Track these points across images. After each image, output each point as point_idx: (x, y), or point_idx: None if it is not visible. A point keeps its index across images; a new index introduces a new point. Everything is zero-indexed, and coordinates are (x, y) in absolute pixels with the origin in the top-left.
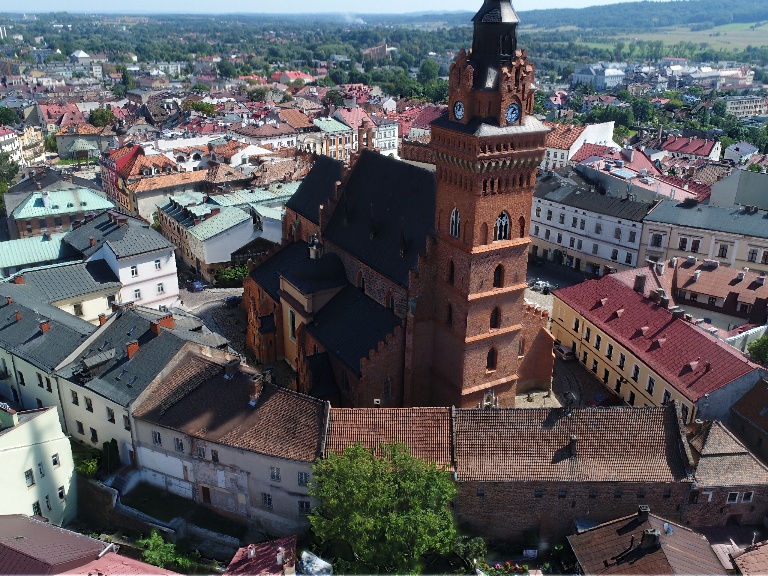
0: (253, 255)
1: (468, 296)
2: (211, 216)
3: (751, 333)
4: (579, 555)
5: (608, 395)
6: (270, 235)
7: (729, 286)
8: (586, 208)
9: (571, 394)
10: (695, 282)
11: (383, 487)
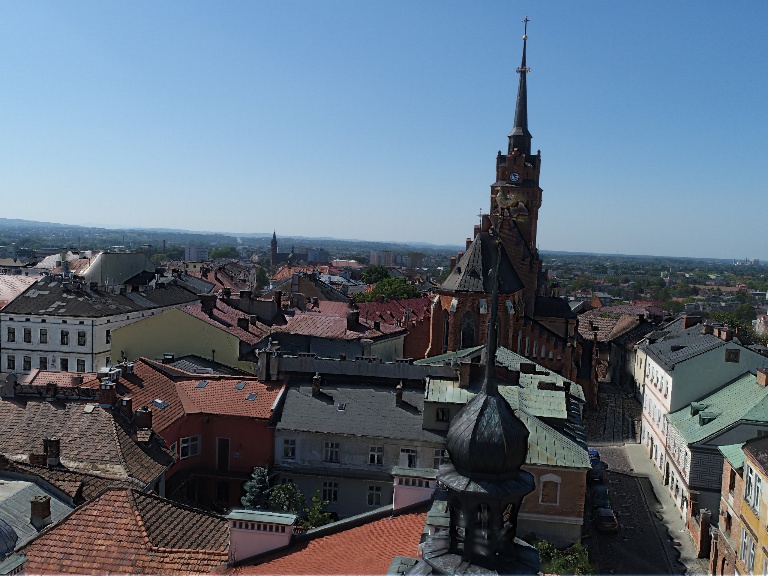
0: None
1: None
2: None
3: None
4: None
5: None
6: None
7: None
8: None
9: None
10: None
11: None
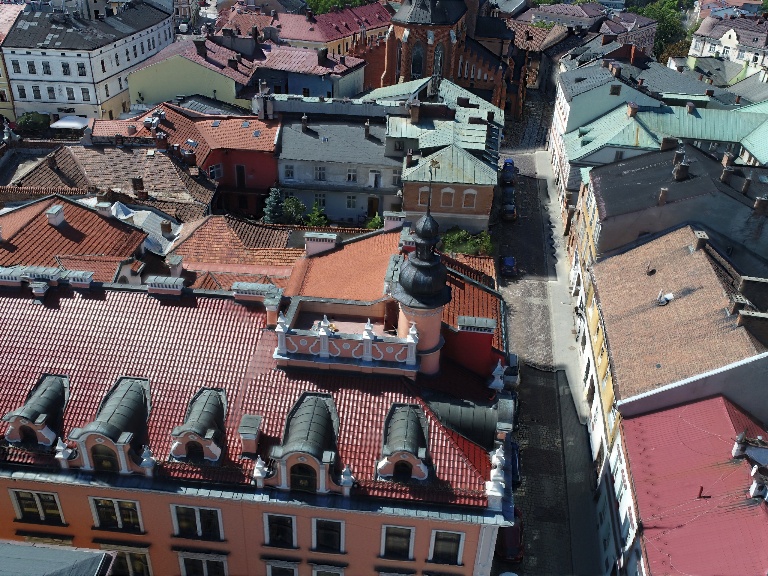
0: None
1: None
2: None
3: None
4: None
5: None
6: None
7: None
8: (152, 24)
9: None
10: None
11: None
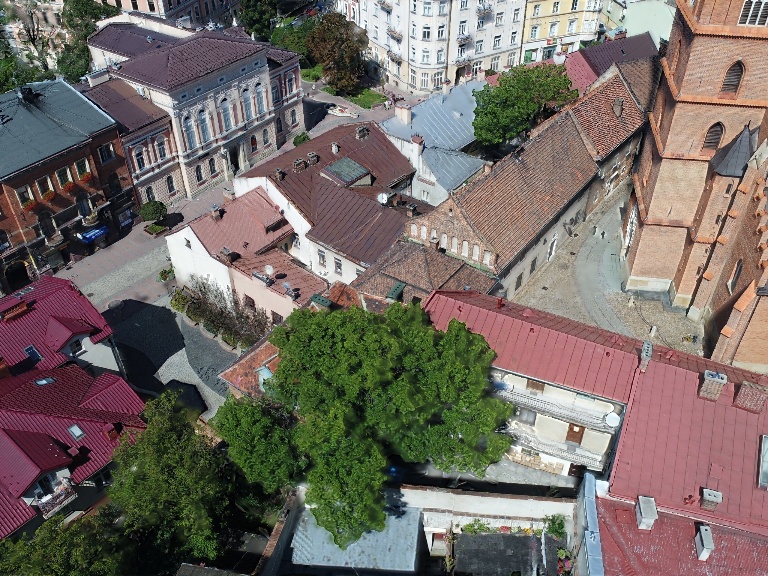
0: None
1: None
2: None
3: (587, 539)
4: (432, 206)
5: None
6: None
7: None
8: None
9: (515, 138)
10: None
11: (511, 72)
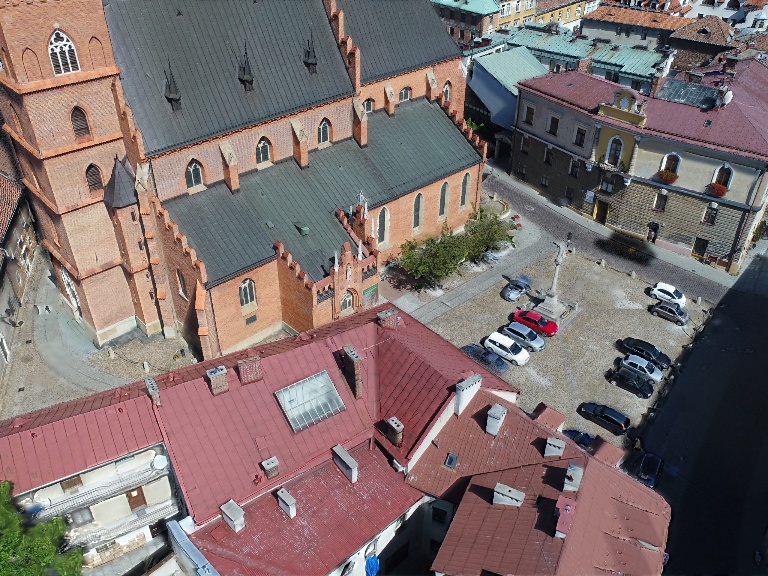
0: (466, 105)
1: (5, 124)
2: (480, 46)
3: None
4: None
5: None
6: (478, 87)
7: (475, 570)
8: None
9: None
10: (490, 502)
11: None
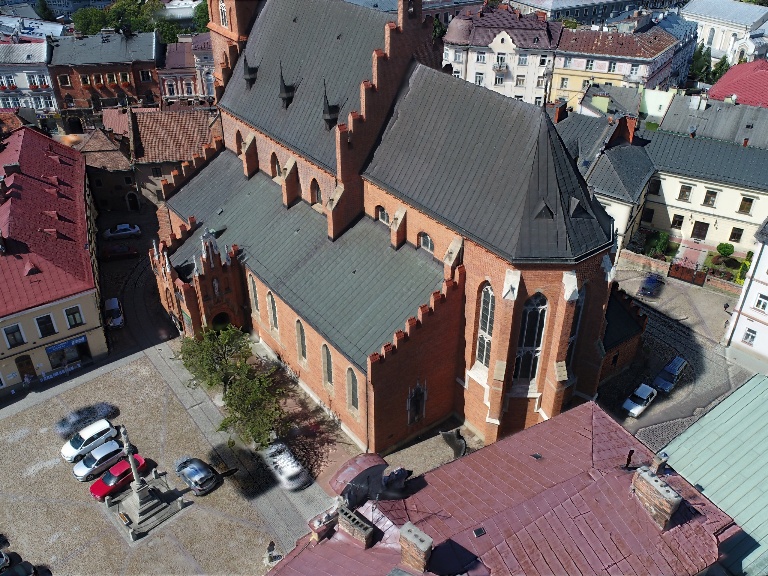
0: None
1: None
2: None
3: None
4: None
5: (110, 255)
6: None
7: None
8: None
9: None
10: None
11: None
